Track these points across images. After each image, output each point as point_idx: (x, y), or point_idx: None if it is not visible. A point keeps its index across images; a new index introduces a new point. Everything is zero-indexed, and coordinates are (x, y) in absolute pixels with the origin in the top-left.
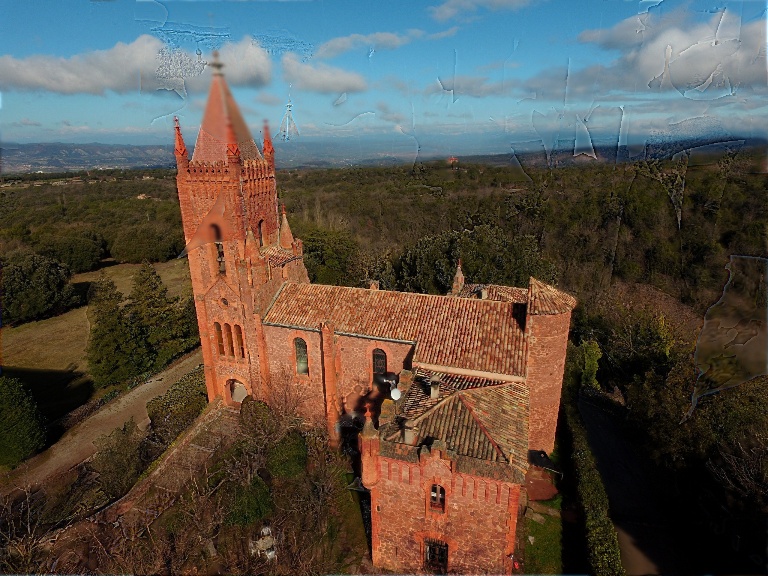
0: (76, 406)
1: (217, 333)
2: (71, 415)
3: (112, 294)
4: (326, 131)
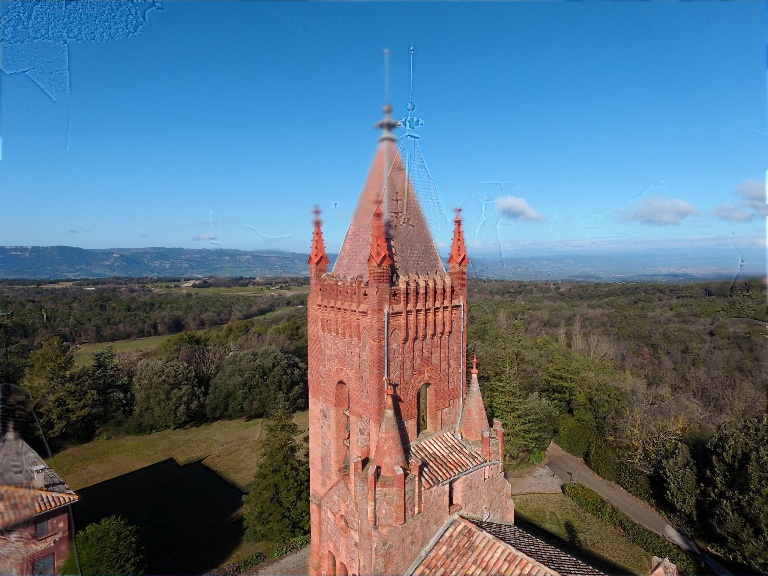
0: (217, 561)
1: (333, 569)
2: None
3: (286, 424)
4: (590, 239)
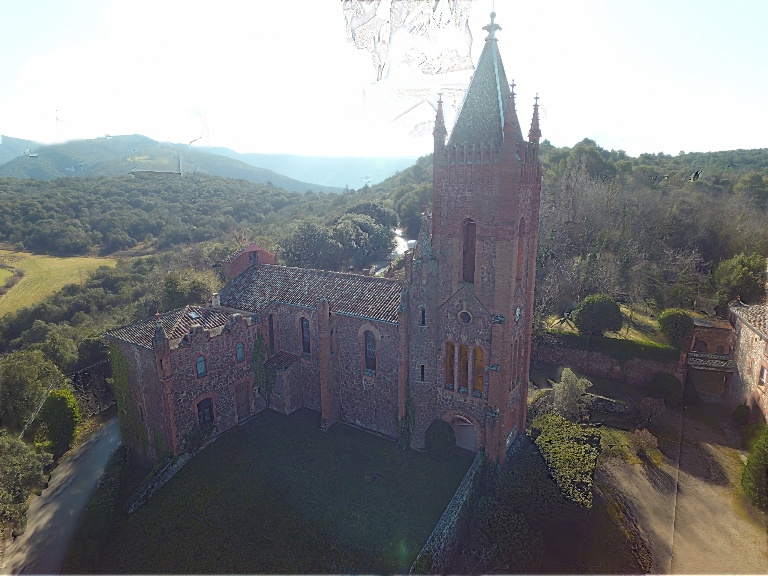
0: None
1: None
2: None
3: None
4: None
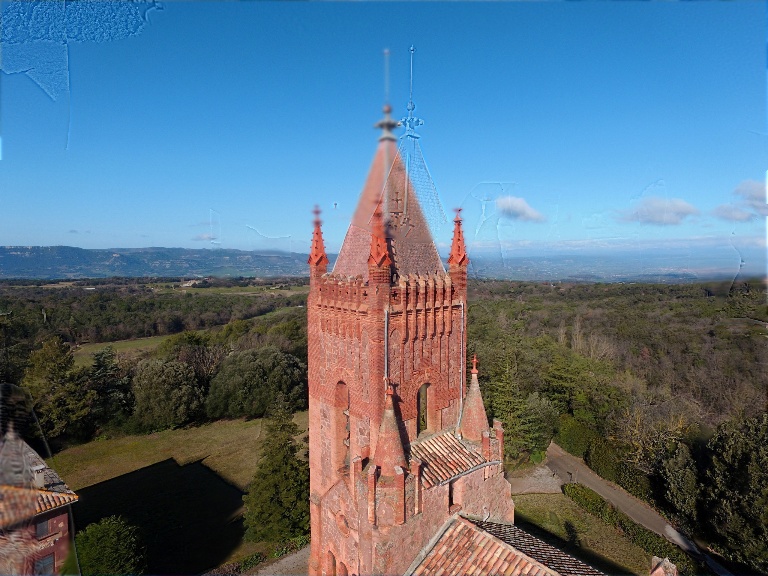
0: (217, 561)
1: (333, 569)
2: None
3: (286, 424)
4: (590, 239)
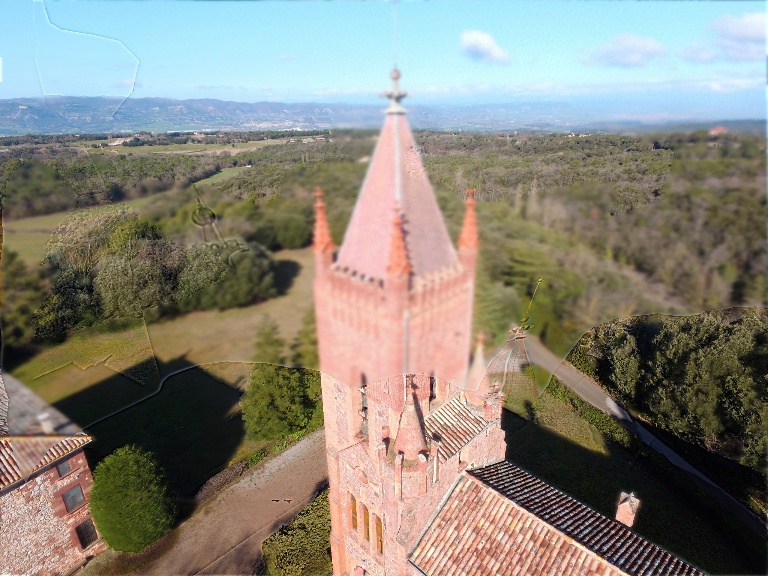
0: (225, 459)
1: (351, 502)
2: (211, 482)
3: None
4: None
